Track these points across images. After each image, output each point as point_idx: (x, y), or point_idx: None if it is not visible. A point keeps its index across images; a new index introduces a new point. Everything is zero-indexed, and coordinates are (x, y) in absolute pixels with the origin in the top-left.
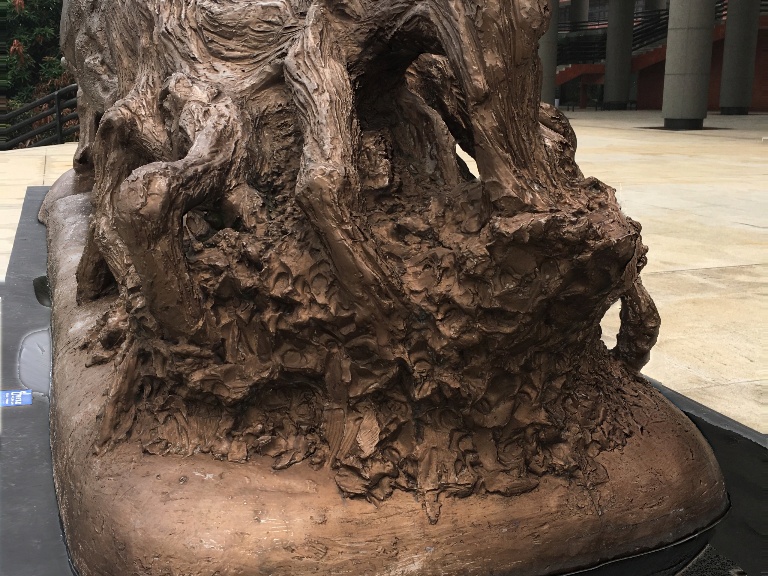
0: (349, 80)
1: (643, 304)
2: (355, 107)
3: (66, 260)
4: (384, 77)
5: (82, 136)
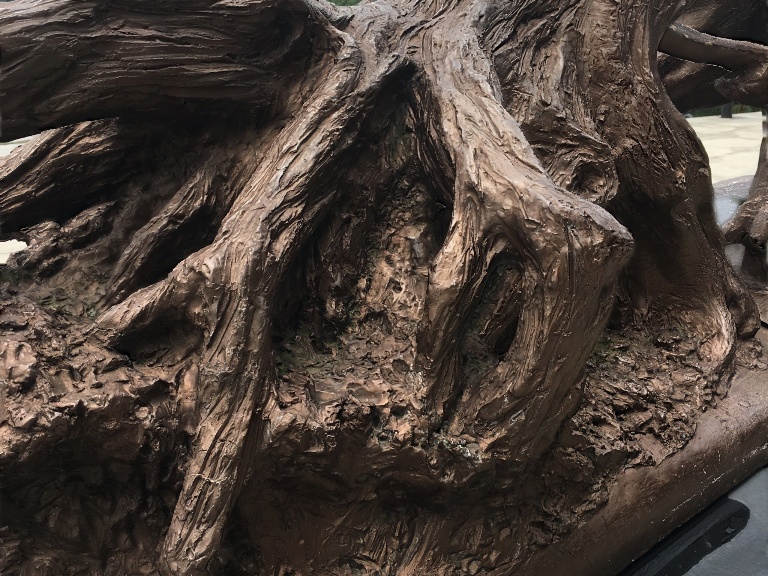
0: (39, 146)
1: (163, 550)
2: (43, 175)
3: None
4: (172, 137)
5: None
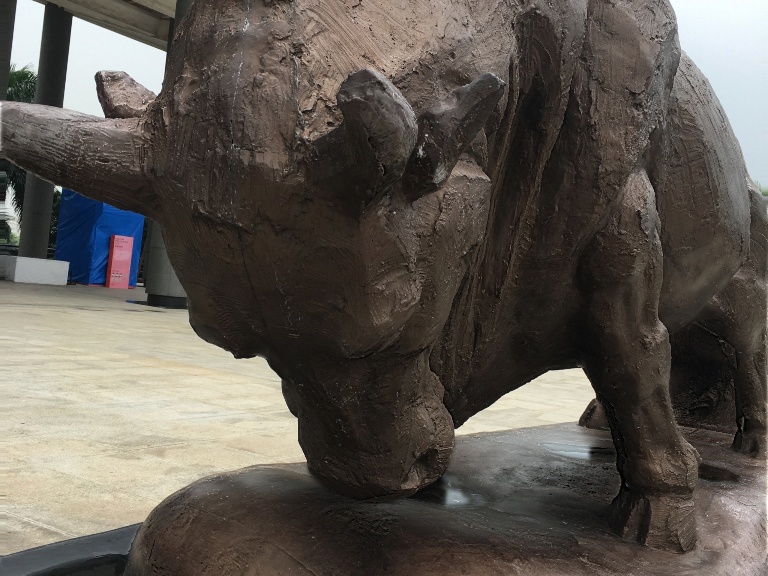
0: None
1: None
2: None
3: None
4: None
5: (674, 419)
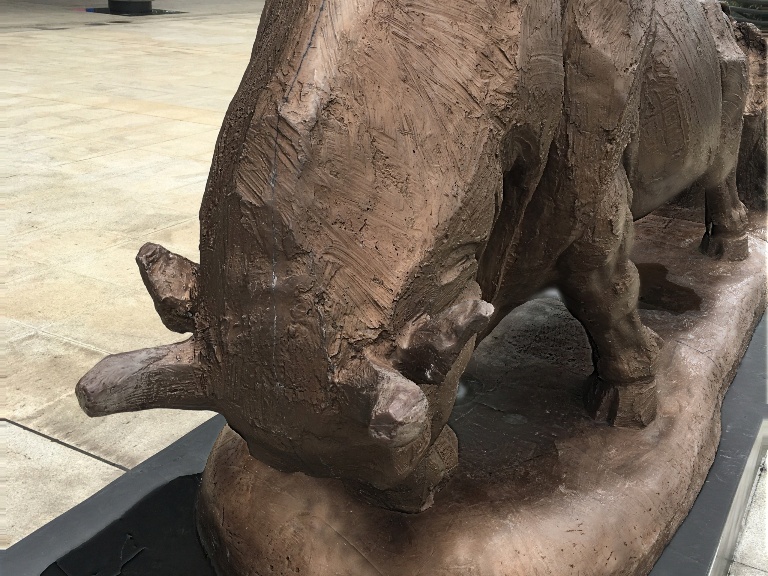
0: None
1: None
2: None
3: (767, 255)
4: None
5: None
